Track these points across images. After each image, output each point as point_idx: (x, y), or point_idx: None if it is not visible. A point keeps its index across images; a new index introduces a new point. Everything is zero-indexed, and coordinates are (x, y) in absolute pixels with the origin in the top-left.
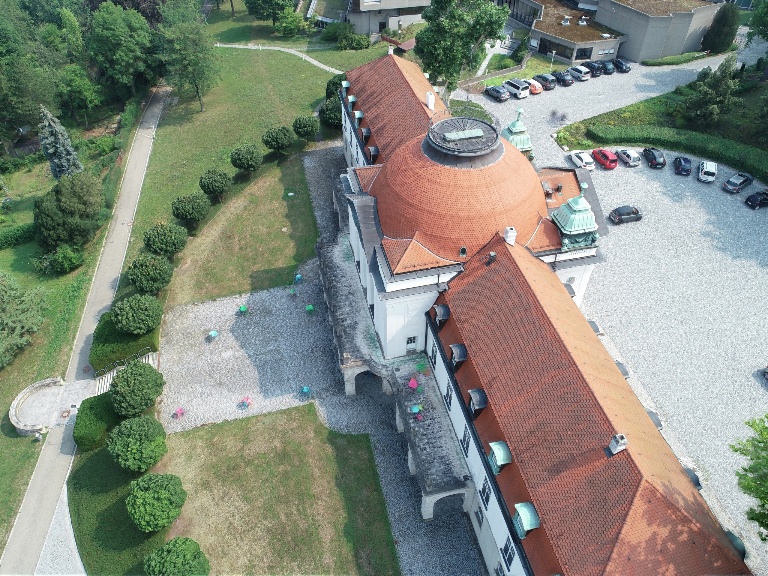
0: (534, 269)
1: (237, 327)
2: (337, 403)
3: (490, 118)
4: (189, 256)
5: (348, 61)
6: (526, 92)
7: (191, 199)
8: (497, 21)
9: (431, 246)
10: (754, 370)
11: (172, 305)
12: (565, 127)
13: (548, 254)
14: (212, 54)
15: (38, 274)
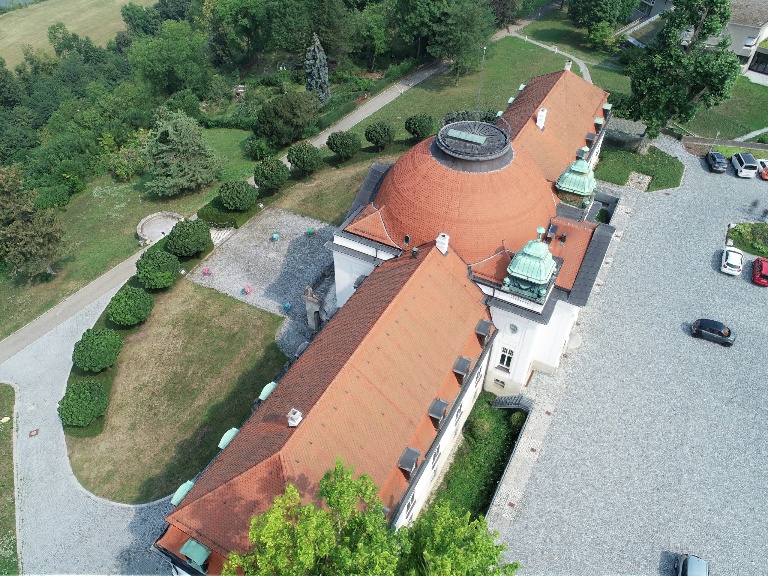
0: (445, 283)
1: (297, 241)
2: (299, 329)
3: (677, 180)
4: (320, 179)
5: (616, 86)
6: (750, 172)
7: (344, 136)
8: (717, 74)
9: (387, 223)
10: (671, 550)
11: (276, 205)
12: (757, 223)
13: (486, 284)
14: (476, 36)
15: (245, 153)
